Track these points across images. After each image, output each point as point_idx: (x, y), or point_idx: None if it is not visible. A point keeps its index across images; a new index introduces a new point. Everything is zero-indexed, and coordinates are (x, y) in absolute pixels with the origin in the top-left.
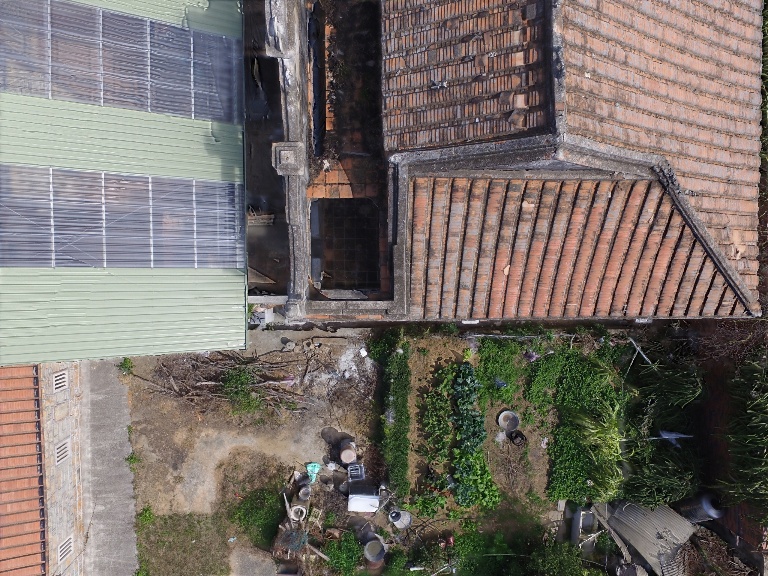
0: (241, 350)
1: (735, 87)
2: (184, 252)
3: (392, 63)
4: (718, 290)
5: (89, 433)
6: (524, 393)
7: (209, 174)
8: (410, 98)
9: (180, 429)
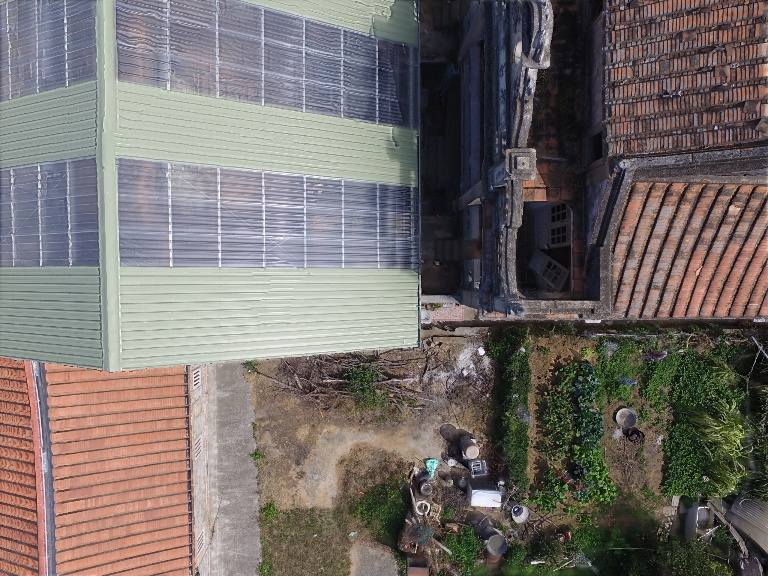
0: None
1: None
2: (369, 253)
3: (618, 72)
4: None
5: (216, 429)
6: (640, 391)
7: (390, 177)
8: (639, 106)
9: (303, 426)
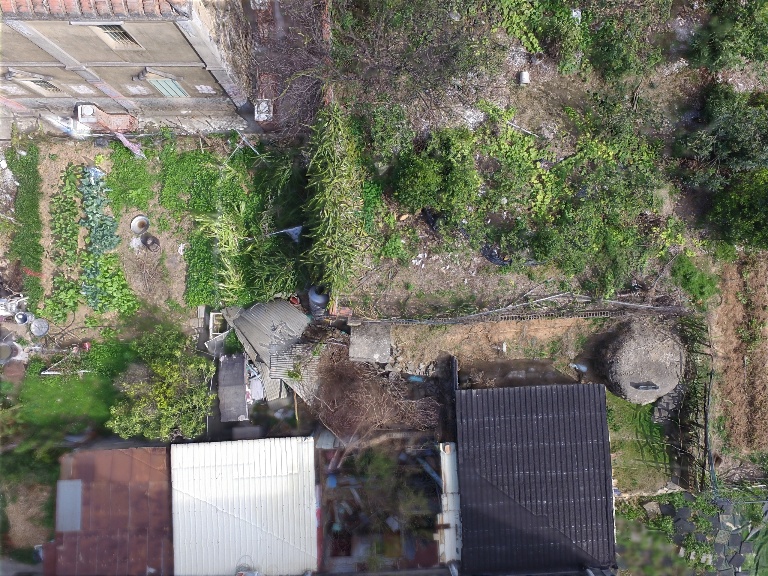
0: None
1: None
2: None
3: None
4: None
5: None
6: (159, 199)
7: None
8: None
9: None
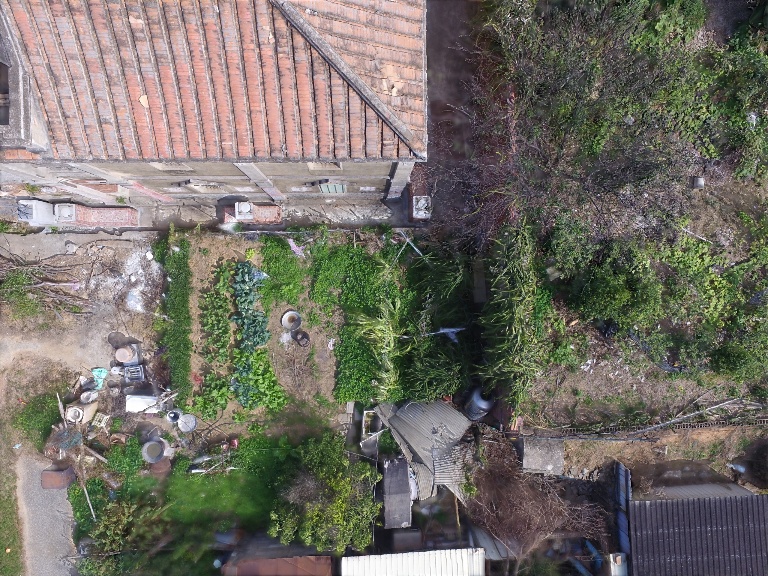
0: (24, 254)
1: None
2: None
3: None
4: (373, 126)
5: None
6: (309, 293)
7: None
8: None
9: None
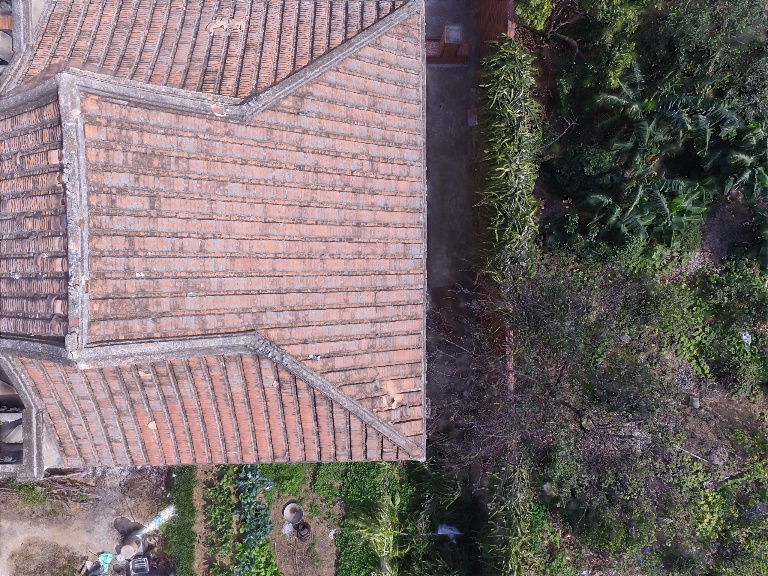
0: None
1: (386, 241)
2: None
3: None
4: (374, 439)
5: None
6: (311, 485)
7: None
8: None
9: None
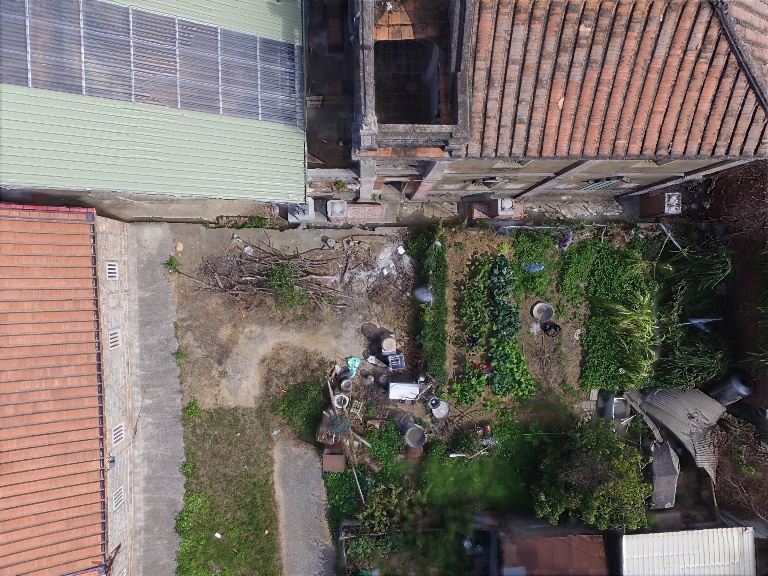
0: (283, 248)
1: None
2: (249, 104)
3: None
4: (758, 126)
5: (137, 328)
6: (557, 286)
7: (271, 32)
8: None
9: (224, 325)
